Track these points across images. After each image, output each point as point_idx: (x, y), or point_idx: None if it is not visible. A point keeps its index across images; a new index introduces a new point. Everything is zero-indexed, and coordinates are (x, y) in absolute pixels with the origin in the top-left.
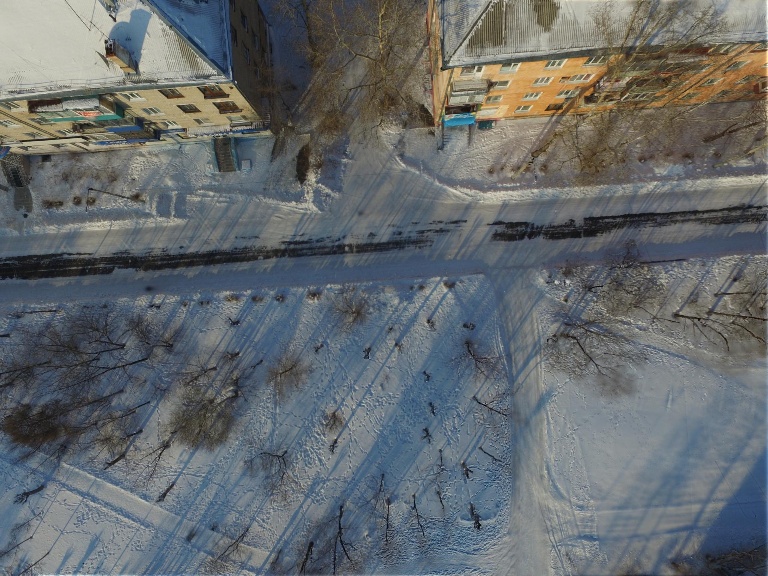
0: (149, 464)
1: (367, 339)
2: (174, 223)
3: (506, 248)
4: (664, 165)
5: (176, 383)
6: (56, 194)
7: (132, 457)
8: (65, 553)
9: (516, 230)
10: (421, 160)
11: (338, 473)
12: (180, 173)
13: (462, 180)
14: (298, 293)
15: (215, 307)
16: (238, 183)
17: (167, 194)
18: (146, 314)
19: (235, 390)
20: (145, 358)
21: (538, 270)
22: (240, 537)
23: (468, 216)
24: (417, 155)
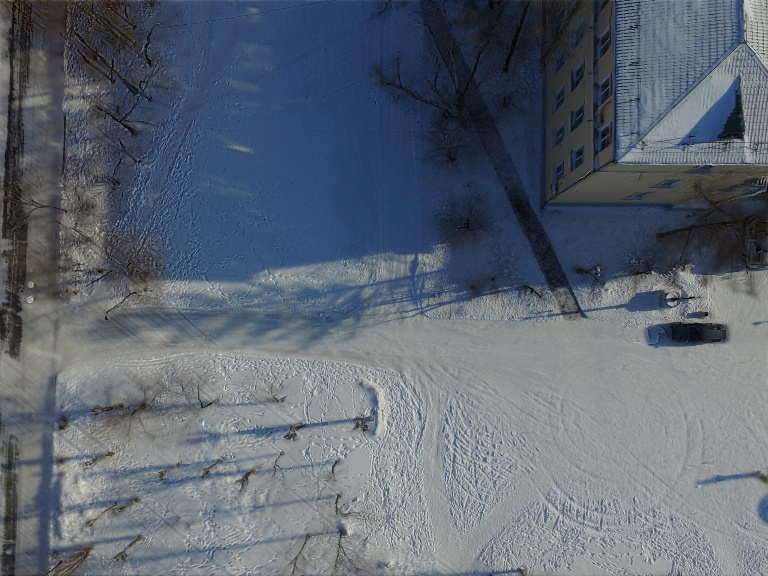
0: None
1: (126, 538)
2: None
3: (30, 341)
4: None
5: None
6: None
7: None
8: None
9: (8, 326)
10: None
11: None
12: None
13: None
14: None
15: None
16: None
17: None
18: None
19: None
20: None
21: (61, 303)
22: None
23: None
24: None
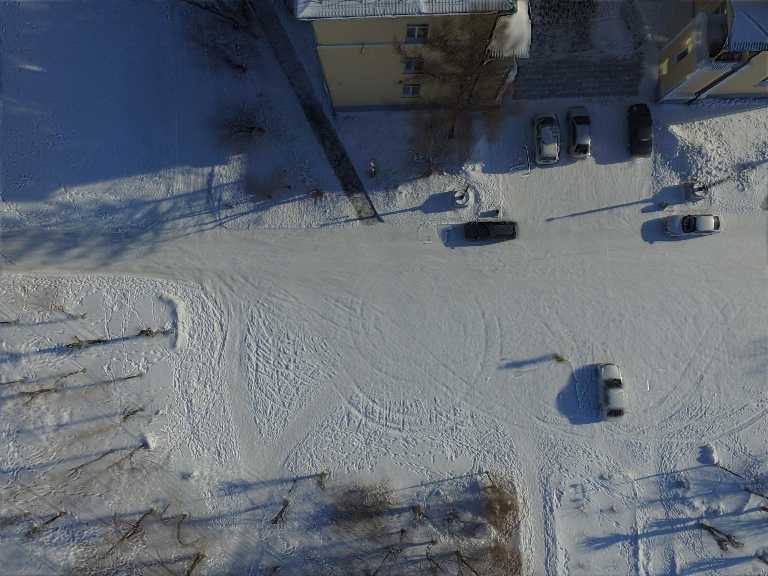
0: None
1: None
2: None
3: None
4: None
5: None
6: None
7: None
8: None
9: None
10: None
11: (105, 513)
12: None
13: None
14: None
15: None
16: None
17: None
18: None
19: None
20: None
21: None
22: None
23: None
24: None
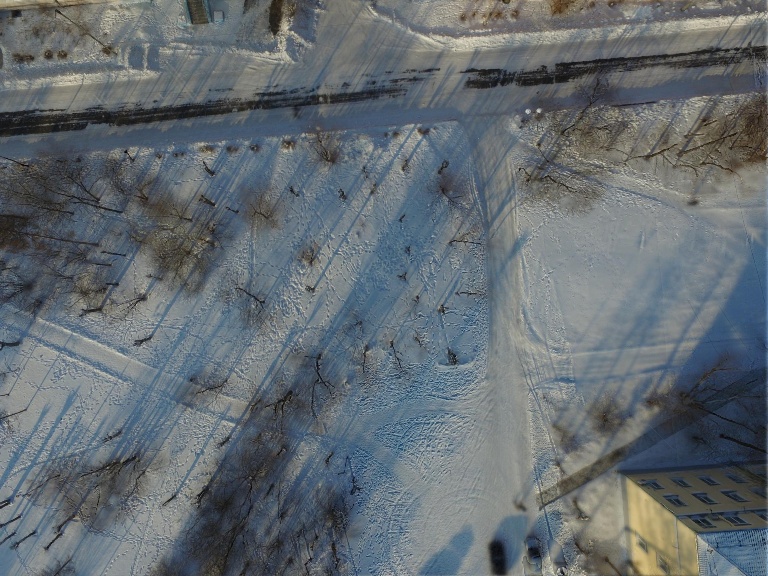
0: (126, 317)
1: (343, 188)
2: (147, 76)
3: (479, 95)
4: (633, 7)
5: (152, 236)
6: (27, 49)
7: (109, 311)
8: (42, 409)
9: (489, 77)
10: (393, 9)
11: (316, 322)
12: (152, 26)
13: (434, 28)
14: (273, 143)
15: (190, 159)
16: (211, 35)
17: (139, 46)
18: (120, 168)
19: (211, 241)
20: (120, 211)
21: (511, 116)
22: (219, 387)
23: (441, 64)
24: (389, 4)
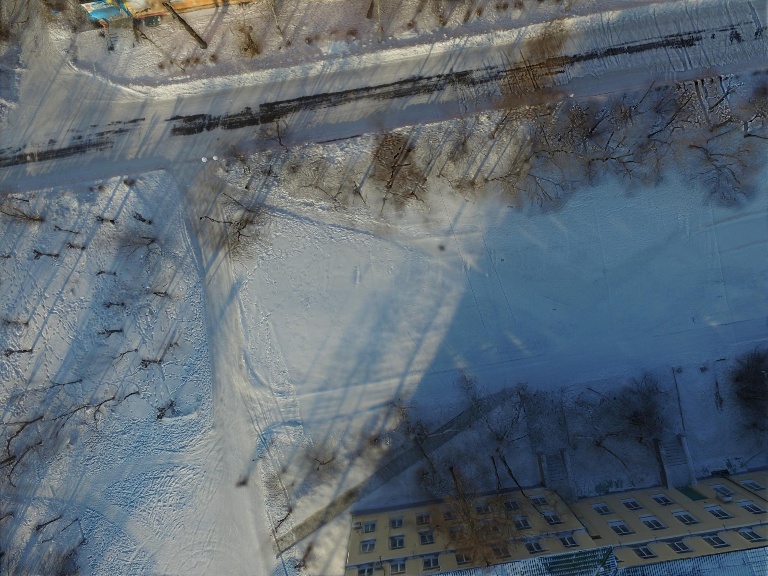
0: None
1: (54, 246)
2: None
3: (186, 142)
4: (327, 43)
5: None
6: None
7: None
8: None
9: (194, 123)
10: (94, 63)
11: (35, 383)
12: None
13: (135, 78)
14: None
15: None
16: None
17: None
18: None
19: None
20: None
21: (219, 161)
22: None
23: (145, 114)
24: (90, 58)
